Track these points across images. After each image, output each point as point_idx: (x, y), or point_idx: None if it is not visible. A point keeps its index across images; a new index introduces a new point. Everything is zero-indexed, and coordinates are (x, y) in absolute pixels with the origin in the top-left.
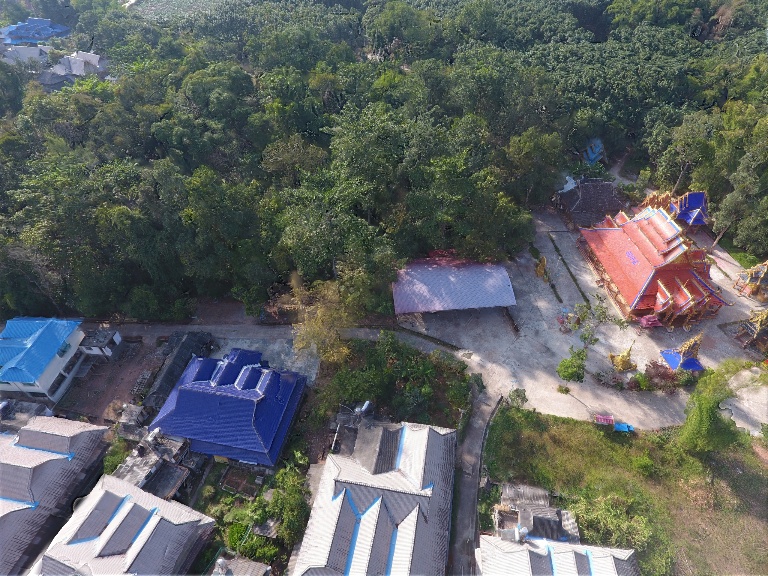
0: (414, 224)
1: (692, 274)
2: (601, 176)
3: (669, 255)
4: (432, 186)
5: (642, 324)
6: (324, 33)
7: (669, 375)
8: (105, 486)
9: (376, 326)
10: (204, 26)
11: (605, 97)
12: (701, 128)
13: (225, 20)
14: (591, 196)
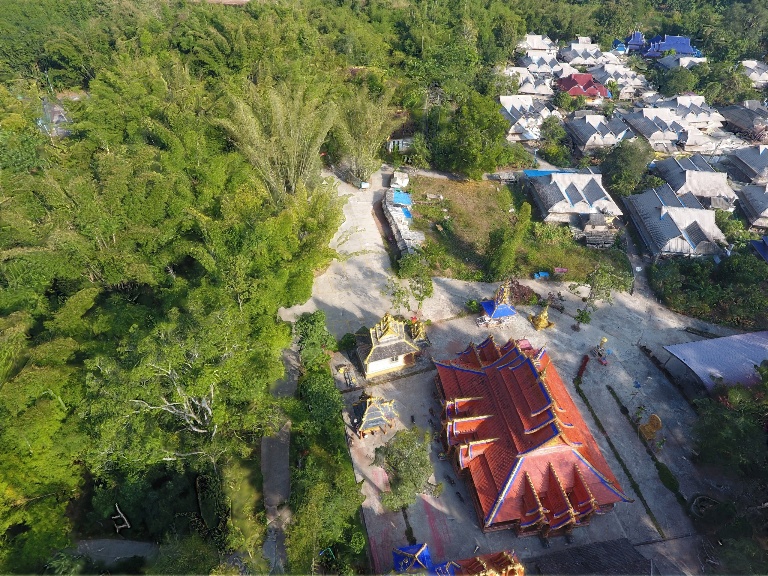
0: None
1: None
2: None
3: None
4: None
5: None
6: None
7: (518, 286)
8: None
9: None
10: None
11: None
12: None
13: None
14: None
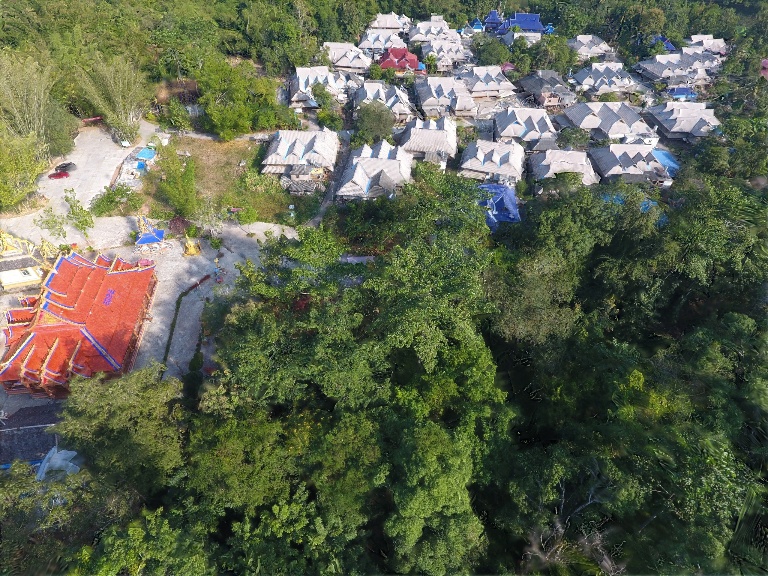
0: None
1: None
2: None
3: None
4: None
5: None
6: None
7: None
8: (514, 169)
9: None
10: None
11: None
12: None
13: None
14: None
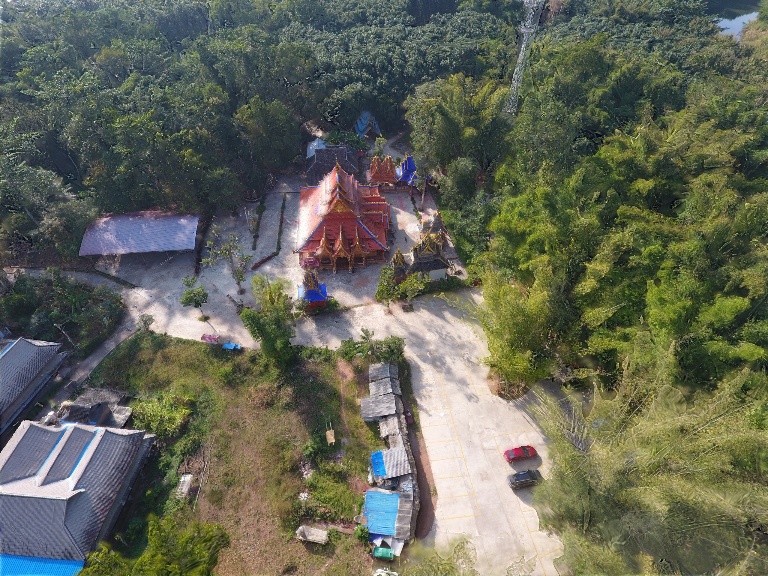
0: (112, 178)
1: (357, 222)
2: (359, 145)
3: (331, 204)
4: (119, 142)
5: (301, 265)
6: (164, 17)
7: None
8: None
9: (72, 269)
10: (58, 10)
11: (383, 74)
12: None
13: (81, 5)
14: (325, 160)
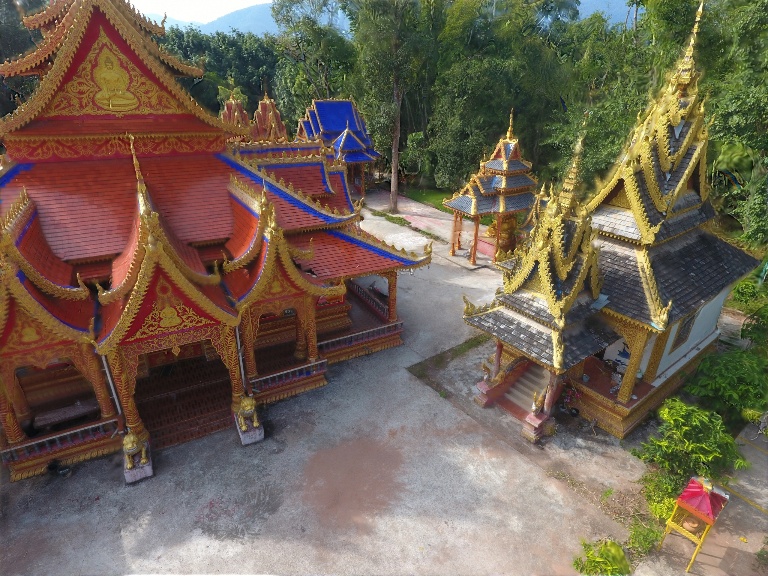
0: None
1: (231, 168)
2: None
3: None
4: None
5: None
6: None
7: None
8: None
9: None
10: None
11: None
12: (316, 4)
13: None
14: None
